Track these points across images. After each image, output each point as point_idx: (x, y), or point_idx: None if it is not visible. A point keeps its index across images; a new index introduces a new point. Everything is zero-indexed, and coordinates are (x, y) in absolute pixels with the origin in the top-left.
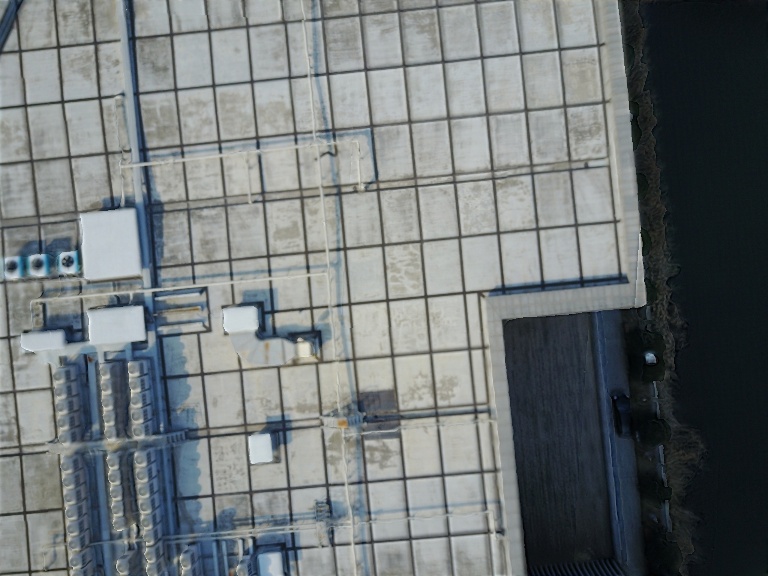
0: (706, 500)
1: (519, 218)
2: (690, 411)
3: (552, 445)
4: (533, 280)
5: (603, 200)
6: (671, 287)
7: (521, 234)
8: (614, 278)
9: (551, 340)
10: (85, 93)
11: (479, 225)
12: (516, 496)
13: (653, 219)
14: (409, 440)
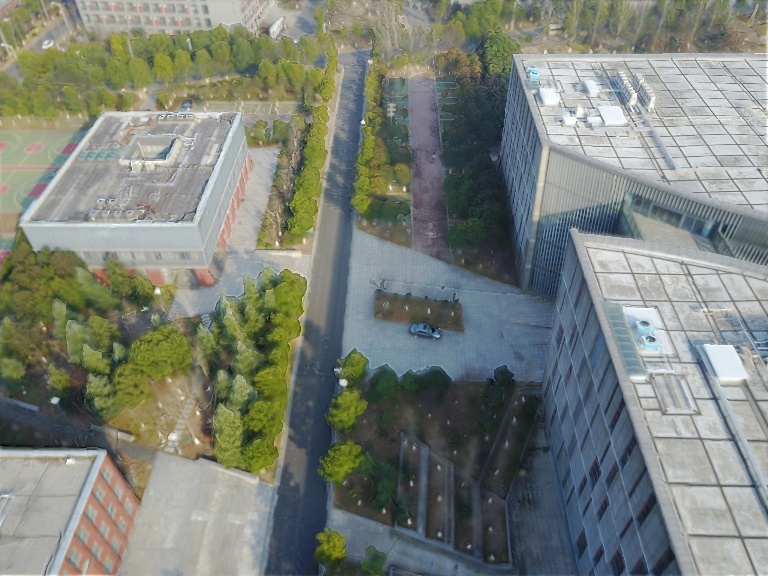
0: None
1: None
2: None
3: None
4: None
5: None
6: None
7: None
8: None
9: None
10: (764, 183)
11: None
12: None
13: None
14: None
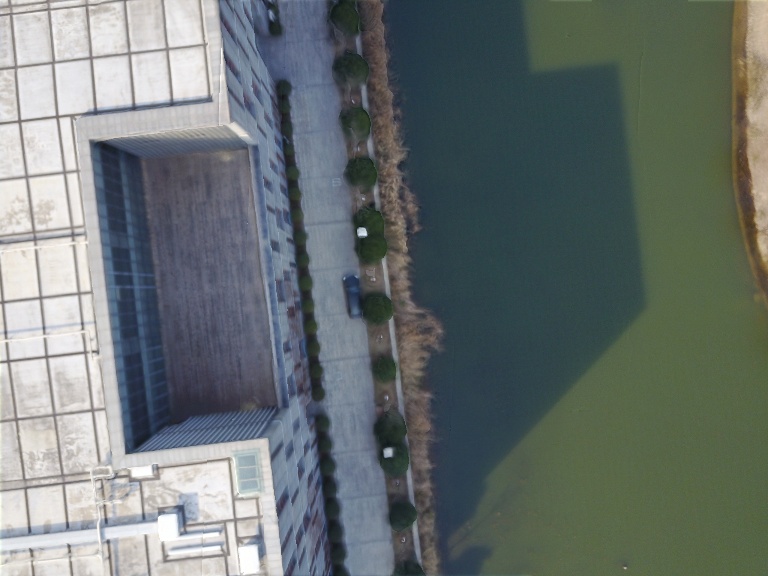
0: (442, 380)
1: (111, 43)
2: (429, 295)
3: (216, 296)
4: (125, 103)
5: (193, 24)
6: (405, 172)
7: (114, 58)
8: (202, 99)
9: (214, 193)
10: None
11: (72, 50)
12: (105, 313)
13: (382, 104)
14: (7, 264)
